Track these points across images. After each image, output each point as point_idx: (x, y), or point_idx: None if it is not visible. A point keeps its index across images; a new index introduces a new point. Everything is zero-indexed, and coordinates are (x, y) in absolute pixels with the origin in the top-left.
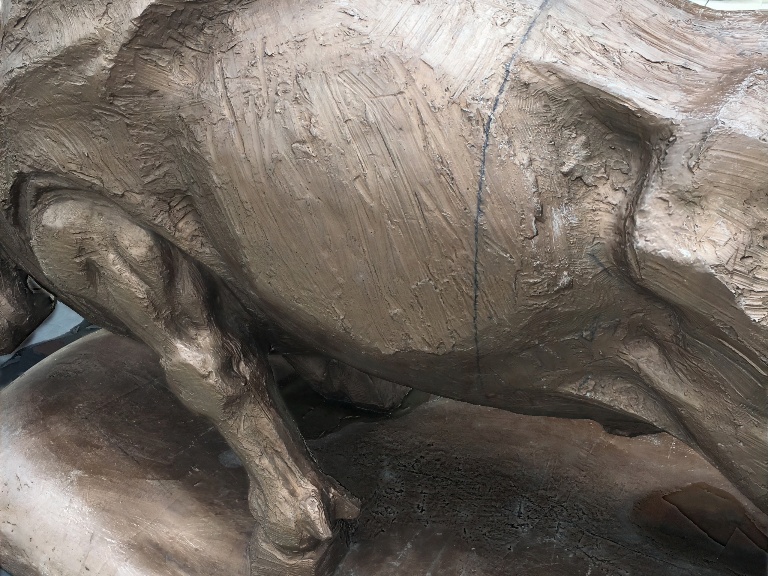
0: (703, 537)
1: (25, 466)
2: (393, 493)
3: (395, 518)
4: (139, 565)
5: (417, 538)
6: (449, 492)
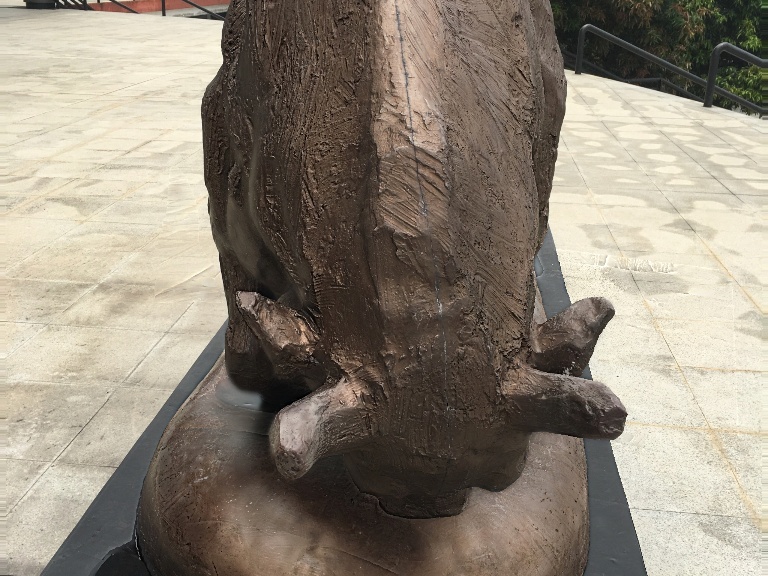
0: None
1: (531, 495)
2: None
3: None
4: (554, 440)
5: None
6: None
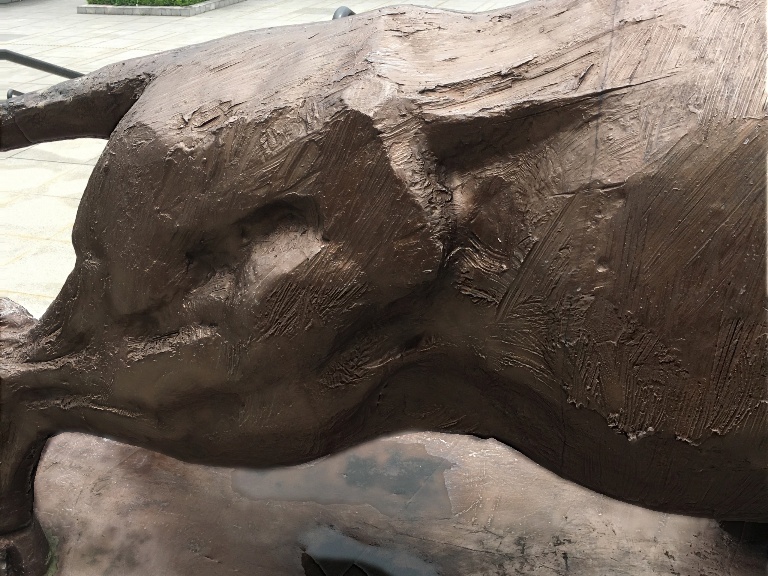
0: (373, 572)
1: None
2: (710, 574)
3: (691, 547)
4: None
5: (658, 528)
6: (649, 573)
